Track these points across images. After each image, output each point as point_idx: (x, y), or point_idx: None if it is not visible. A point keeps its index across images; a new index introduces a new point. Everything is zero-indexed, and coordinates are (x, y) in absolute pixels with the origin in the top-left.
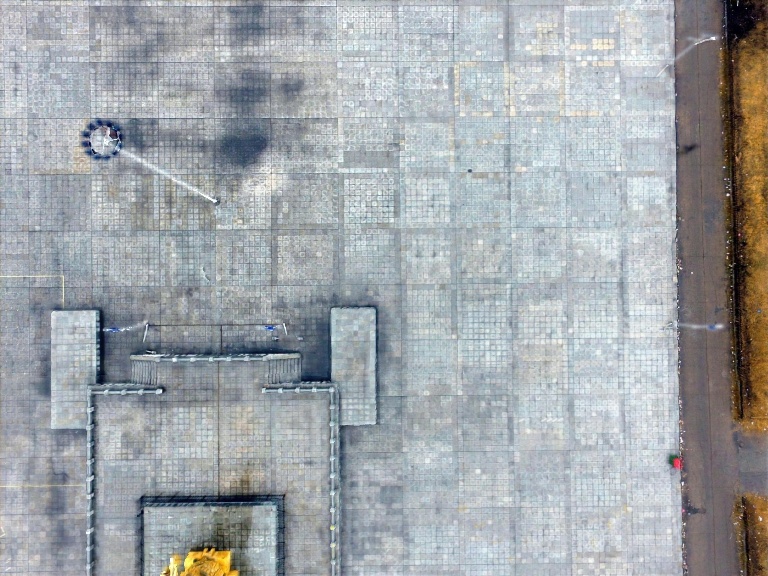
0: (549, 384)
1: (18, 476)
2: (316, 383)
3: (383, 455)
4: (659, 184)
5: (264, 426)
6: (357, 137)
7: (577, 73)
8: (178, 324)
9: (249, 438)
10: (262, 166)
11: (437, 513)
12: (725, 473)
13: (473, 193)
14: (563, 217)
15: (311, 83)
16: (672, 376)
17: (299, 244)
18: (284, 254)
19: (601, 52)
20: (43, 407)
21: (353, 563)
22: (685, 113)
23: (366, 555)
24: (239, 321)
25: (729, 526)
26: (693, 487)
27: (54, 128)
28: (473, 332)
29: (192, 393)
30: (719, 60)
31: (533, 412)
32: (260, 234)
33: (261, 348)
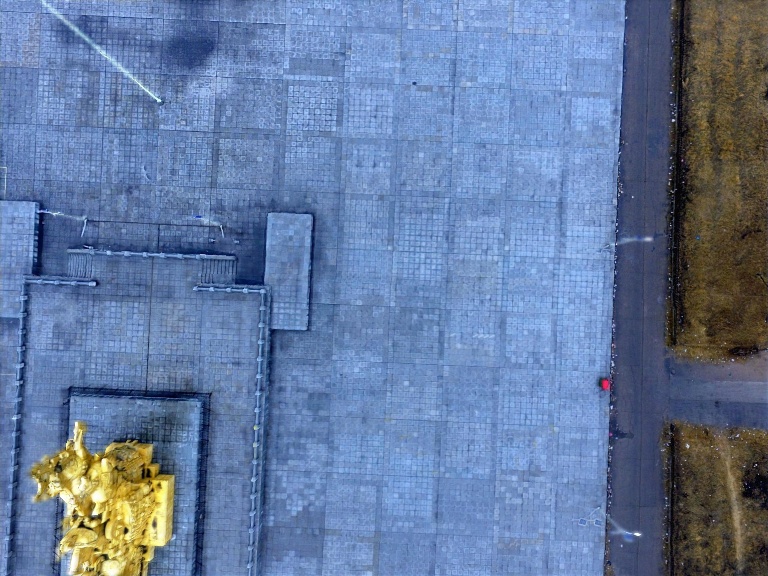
0: (482, 300)
1: None
2: (249, 285)
3: (313, 362)
4: (604, 106)
5: (195, 324)
6: (304, 44)
7: None
8: (116, 221)
9: (179, 335)
10: (208, 69)
11: (363, 422)
12: (655, 399)
13: (416, 106)
14: (505, 134)
15: None
16: (607, 299)
17: (240, 148)
18: (225, 157)
19: None
20: None
21: (277, 467)
22: (634, 36)
23: (290, 460)
24: (177, 221)
25: (656, 452)
26: (622, 411)
27: (5, 21)
28: (409, 244)
29: (125, 288)
30: None
31: (465, 327)
32: (202, 136)
33: (197, 249)
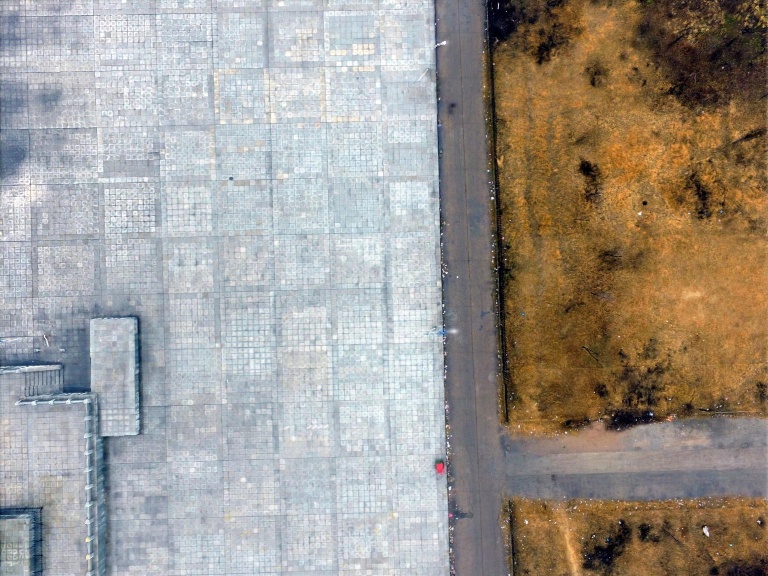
0: (314, 391)
1: None
2: (74, 394)
3: (147, 465)
4: (422, 189)
5: (21, 439)
6: (117, 146)
7: (337, 79)
8: None
9: (6, 451)
10: (21, 177)
11: (202, 522)
12: (492, 477)
13: (235, 201)
14: (326, 223)
15: (69, 93)
16: (437, 381)
17: (60, 255)
18: (44, 265)
19: (361, 57)
20: None
21: (118, 574)
22: (448, 117)
23: (131, 566)
24: None
25: (497, 530)
26: (460, 491)
27: None
28: (237, 340)
29: None
30: (482, 63)
31: (298, 419)
32: (20, 246)
33: (23, 360)
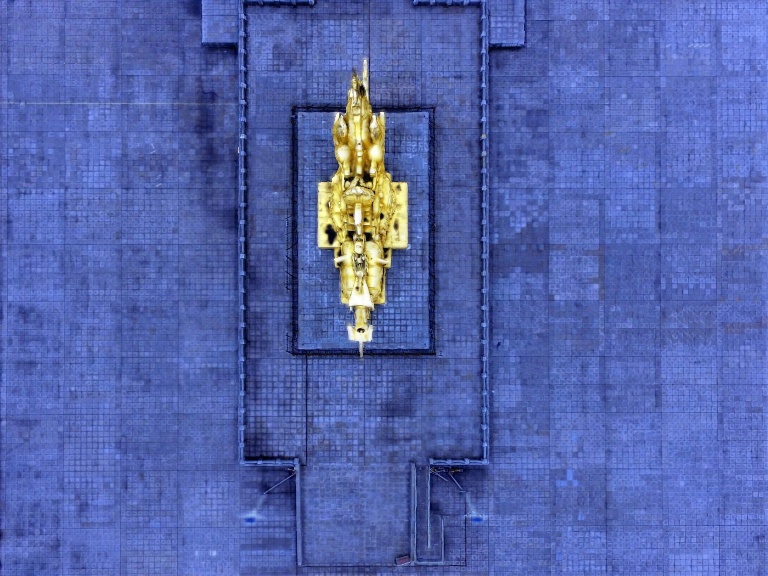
0: (697, 9)
1: (168, 94)
2: None
3: (529, 79)
4: None
5: (414, 40)
6: None
7: None
8: None
9: (399, 51)
10: None
11: (583, 137)
12: None
13: None
14: None
15: None
16: None
17: None
18: None
19: None
20: (192, 26)
21: (499, 185)
22: None
23: (512, 178)
24: None
25: None
26: None
27: None
28: None
29: (343, 6)
30: None
31: (680, 38)
32: None
33: None
